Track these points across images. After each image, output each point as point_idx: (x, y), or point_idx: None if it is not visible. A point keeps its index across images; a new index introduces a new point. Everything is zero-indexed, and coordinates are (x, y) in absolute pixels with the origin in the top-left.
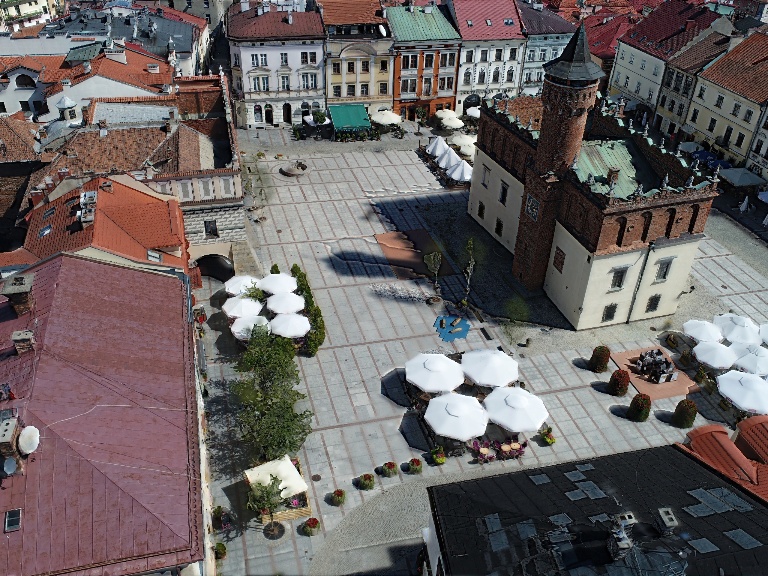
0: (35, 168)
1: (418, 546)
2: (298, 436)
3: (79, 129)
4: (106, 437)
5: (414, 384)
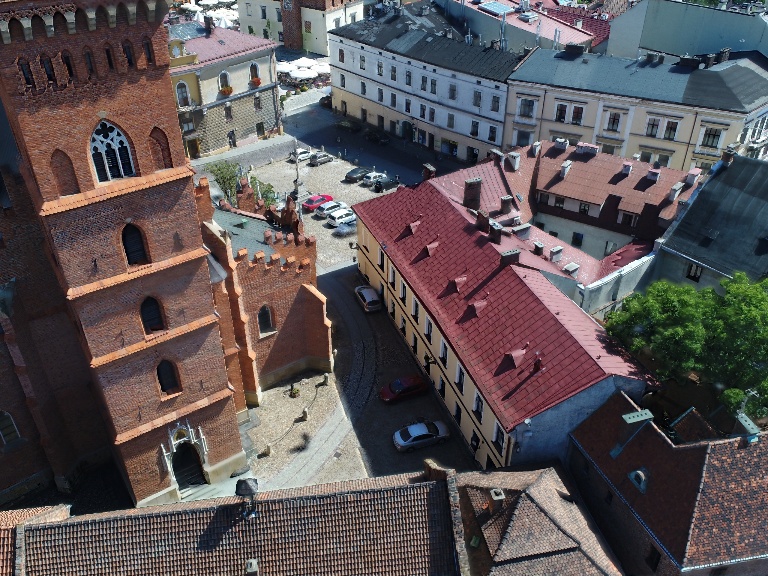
0: None
1: (317, 104)
2: None
3: None
4: None
5: (279, 71)
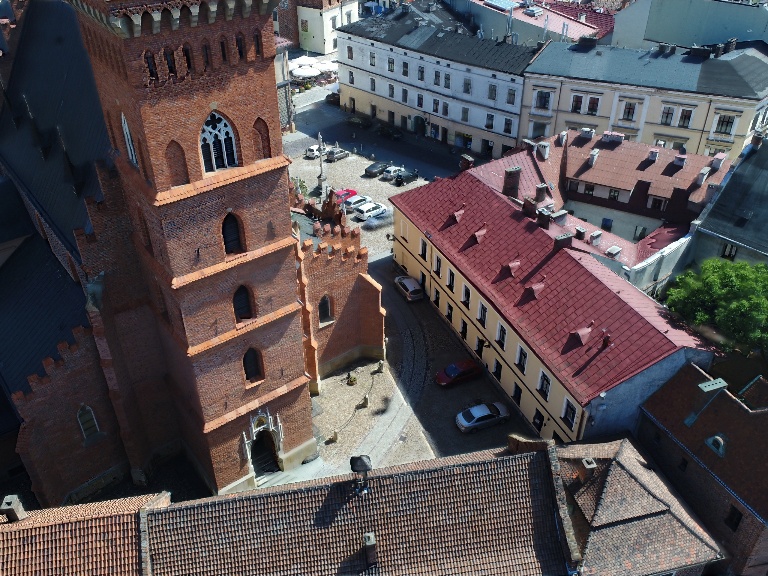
0: None
1: None
2: None
3: None
4: None
5: None
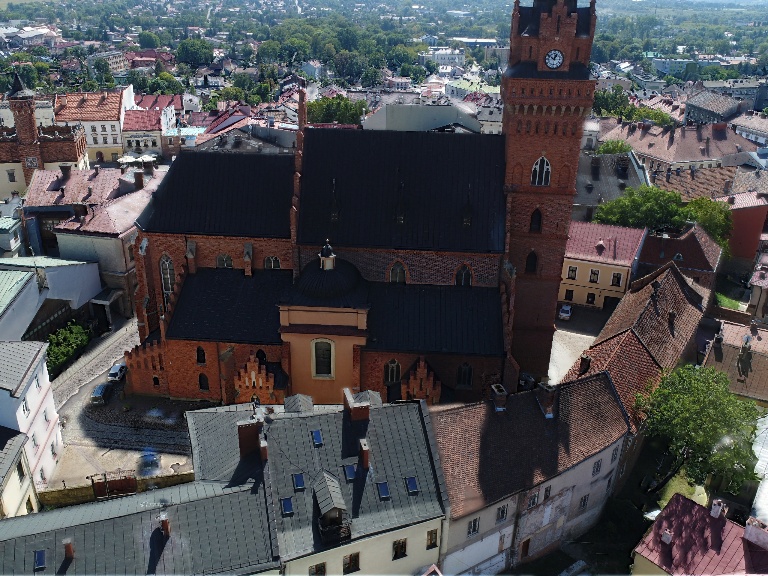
0: None
1: None
2: None
3: None
4: None
5: None
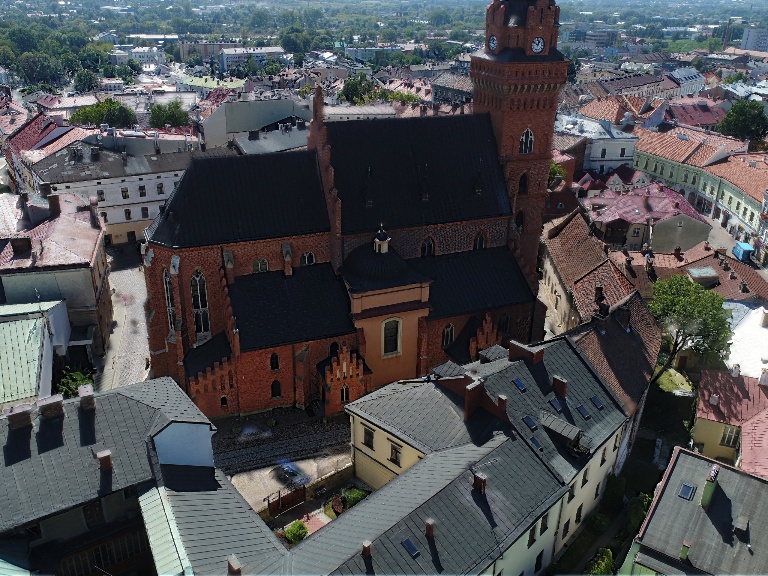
0: None
1: None
2: None
3: None
4: None
5: None
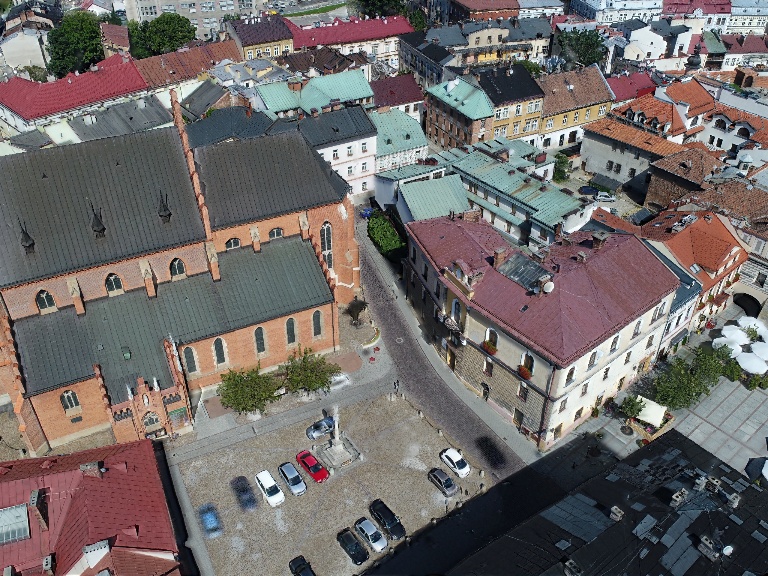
0: (697, 189)
1: None
2: (680, 403)
3: (737, 178)
4: (575, 308)
5: None
